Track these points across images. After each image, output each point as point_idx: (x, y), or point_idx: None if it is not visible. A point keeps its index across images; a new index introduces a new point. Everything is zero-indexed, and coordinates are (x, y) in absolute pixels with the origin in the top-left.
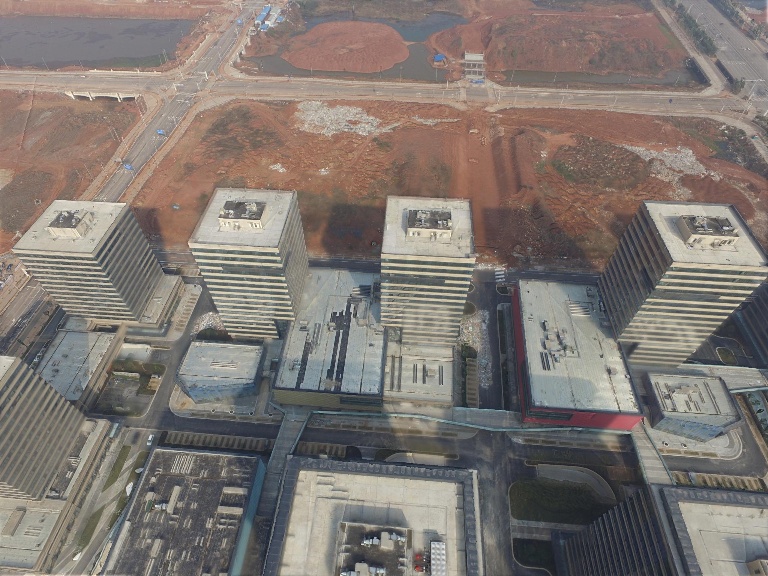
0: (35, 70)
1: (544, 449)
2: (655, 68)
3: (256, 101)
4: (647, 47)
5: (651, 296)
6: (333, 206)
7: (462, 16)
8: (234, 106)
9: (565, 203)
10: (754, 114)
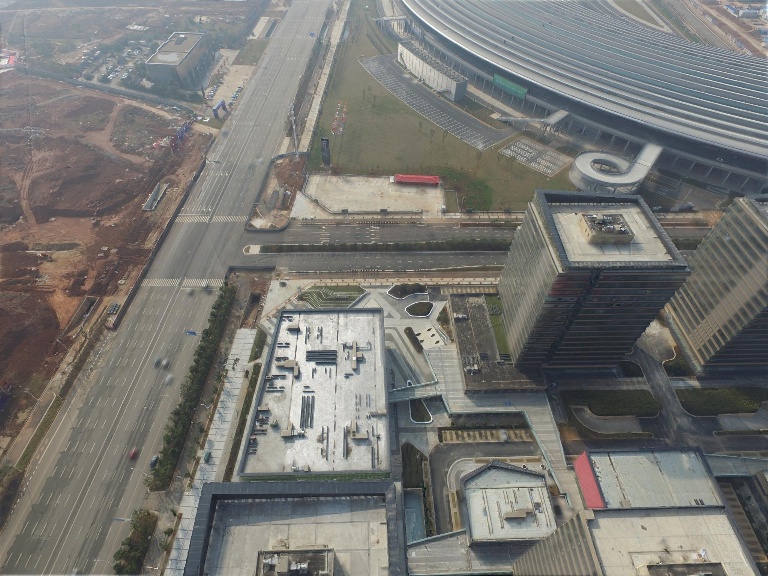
0: None
1: None
2: None
3: None
4: None
5: None
6: None
7: None
8: None
9: None
10: None
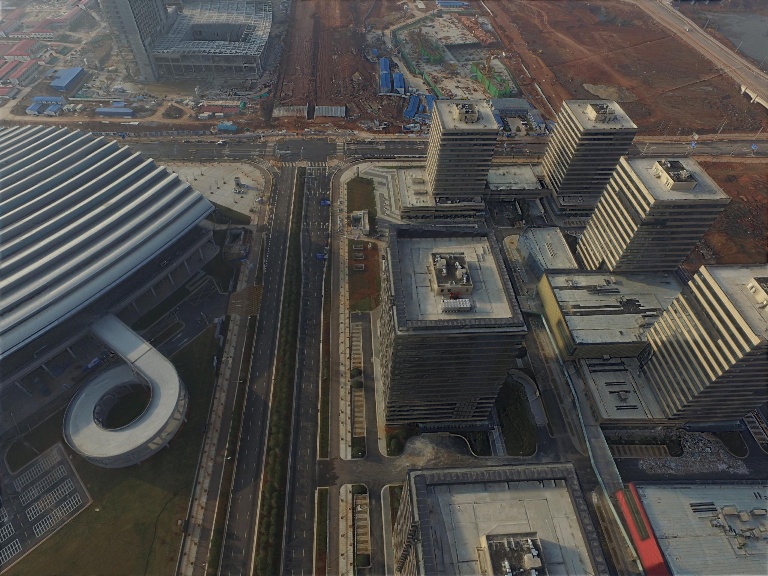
0: (750, 62)
1: None
2: None
3: None
4: None
5: None
6: None
7: None
8: None
9: None
10: None
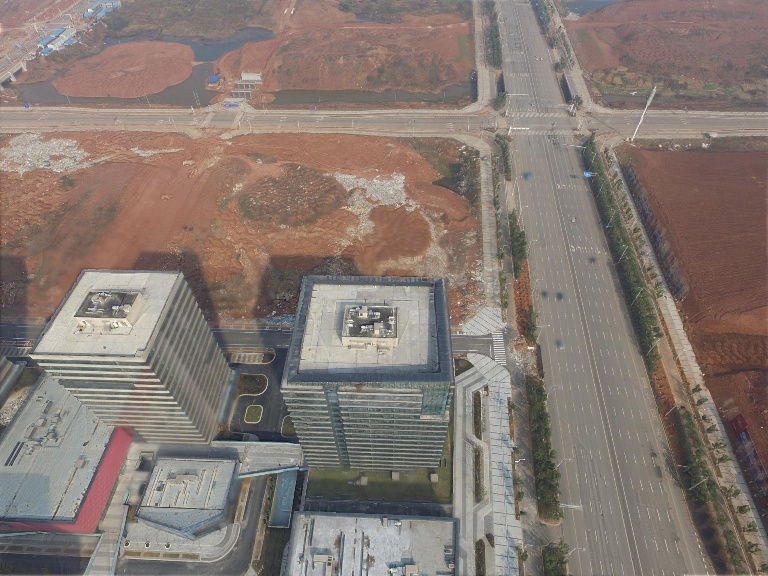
0: None
1: (3, 558)
2: (436, 83)
3: None
4: (431, 61)
5: (68, 385)
6: None
7: (273, 31)
8: None
9: (226, 244)
10: (502, 132)
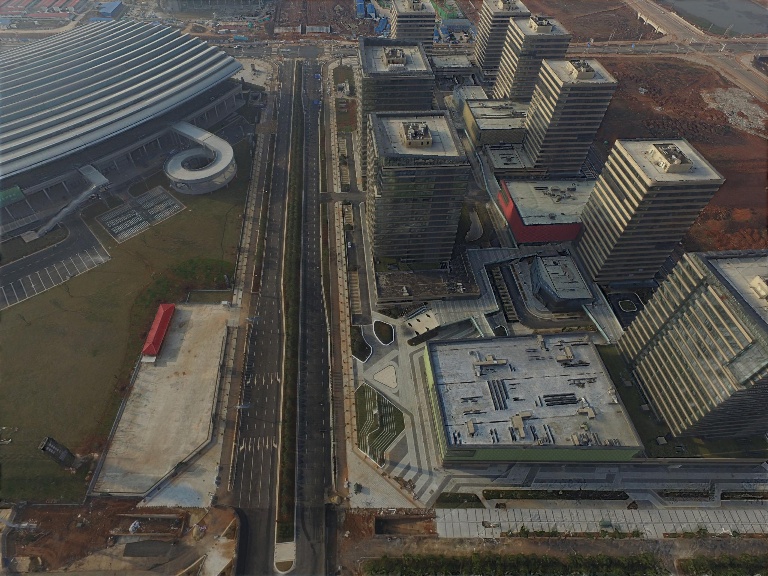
0: None
1: None
2: None
3: (719, 75)
4: None
5: (603, 174)
6: (623, 115)
7: None
8: (700, 68)
9: (761, 243)
10: None
